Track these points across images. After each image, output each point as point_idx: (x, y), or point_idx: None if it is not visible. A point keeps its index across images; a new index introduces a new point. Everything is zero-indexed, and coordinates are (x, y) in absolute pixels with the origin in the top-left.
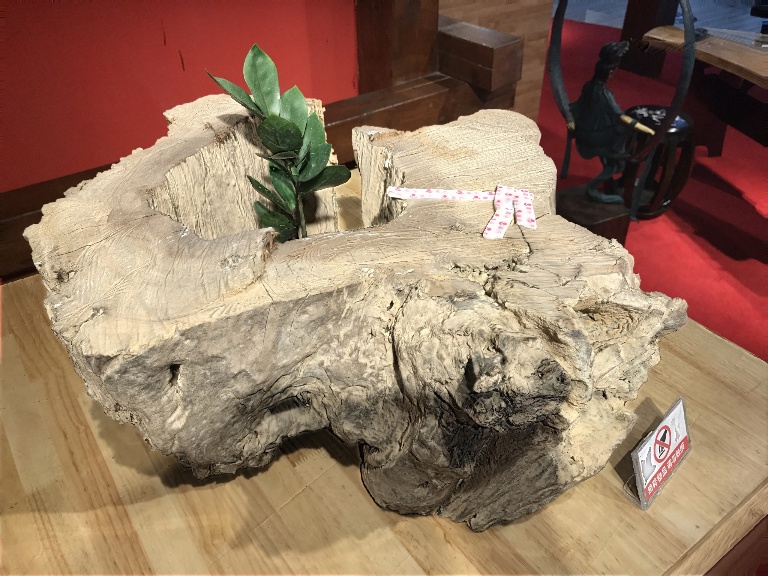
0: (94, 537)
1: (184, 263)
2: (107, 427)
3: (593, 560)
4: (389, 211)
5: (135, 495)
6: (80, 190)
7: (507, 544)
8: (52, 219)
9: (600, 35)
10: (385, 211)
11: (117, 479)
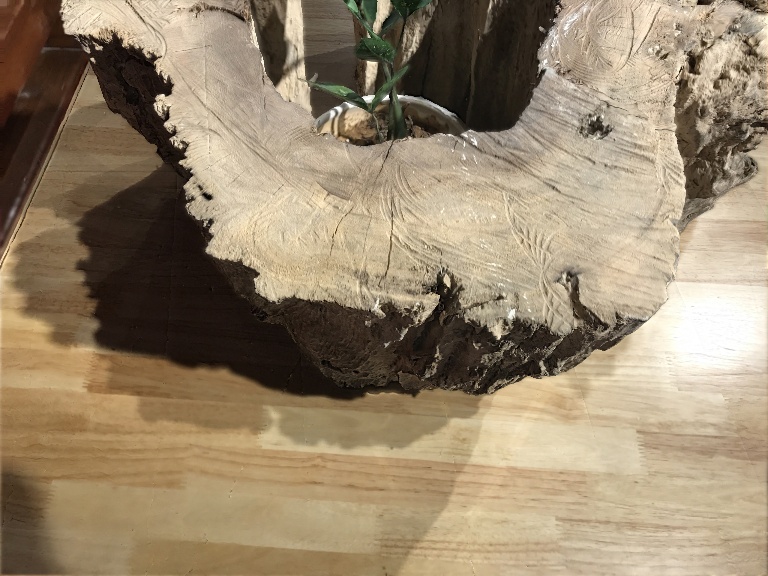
0: (488, 507)
1: (544, 165)
2: (340, 436)
3: (749, 185)
4: (431, 2)
5: (461, 449)
6: (214, 198)
7: (705, 220)
8: (266, 255)
9: None
10: None
11: (426, 456)
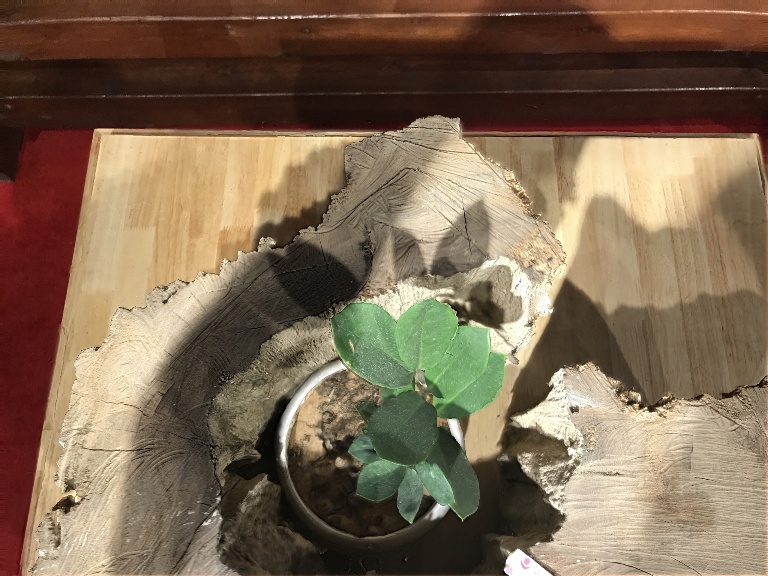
0: None
1: None
2: None
3: None
4: None
5: None
6: (164, 305)
7: None
8: (111, 353)
9: None
10: (537, 476)
11: None
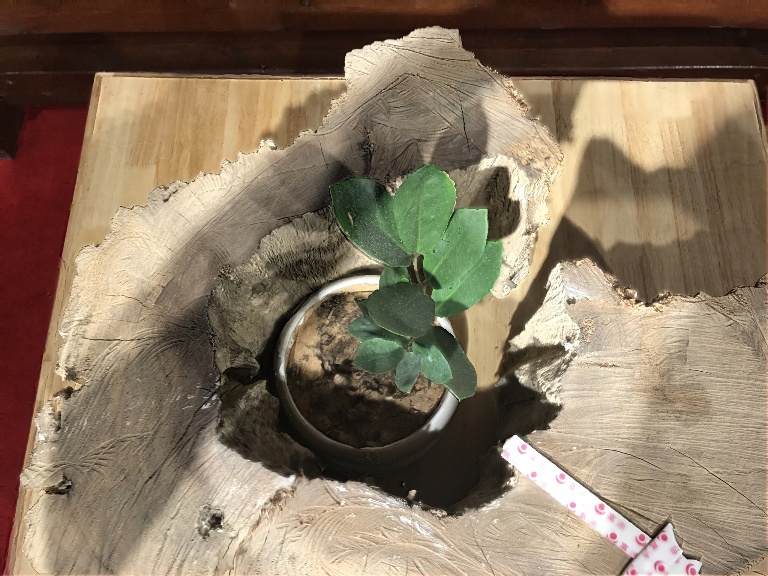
0: None
1: (174, 470)
2: None
3: None
4: (538, 386)
5: None
6: (164, 203)
7: None
8: (112, 249)
9: None
10: (534, 380)
11: None
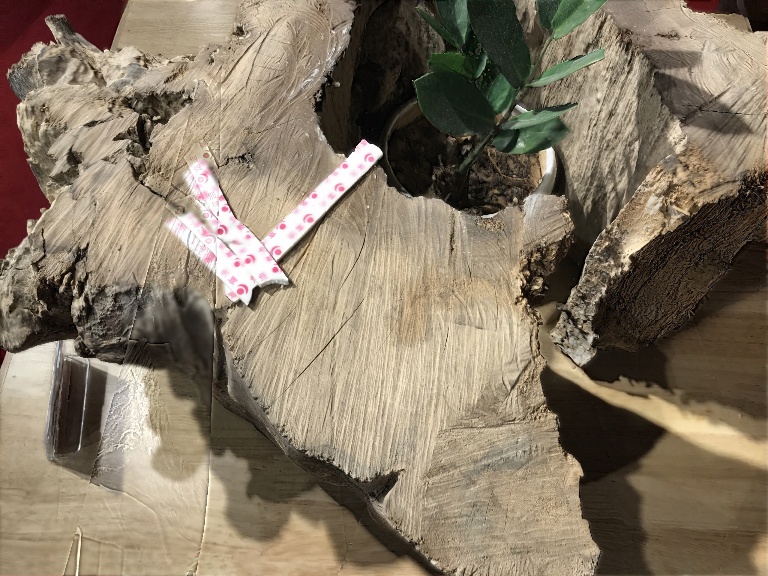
0: None
1: None
2: None
3: None
4: None
5: None
6: None
7: None
8: None
9: (158, 334)
10: None
11: None
